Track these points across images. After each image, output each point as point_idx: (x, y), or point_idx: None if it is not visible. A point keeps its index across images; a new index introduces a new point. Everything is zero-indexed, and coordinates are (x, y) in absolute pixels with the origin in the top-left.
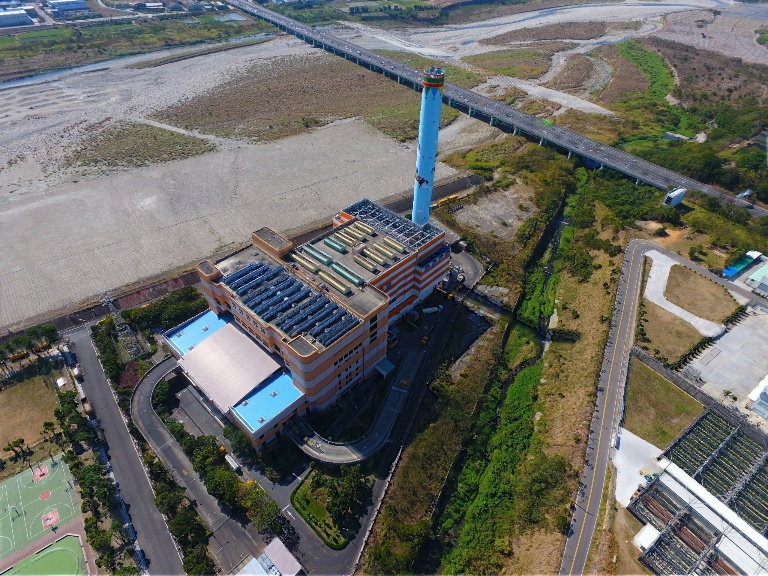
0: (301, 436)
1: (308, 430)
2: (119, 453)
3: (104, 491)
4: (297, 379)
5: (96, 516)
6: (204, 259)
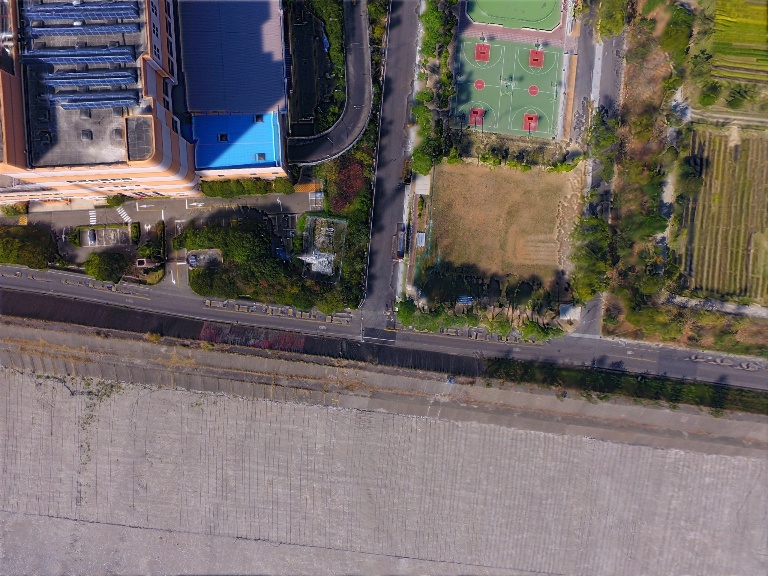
0: None
1: None
2: (401, 81)
3: None
4: None
5: None
6: (142, 370)
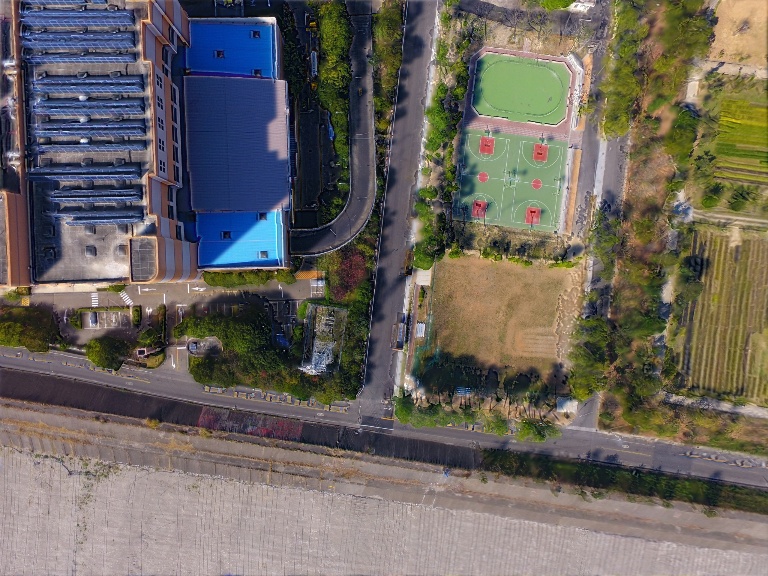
0: (232, 15)
1: (220, 15)
2: (406, 172)
3: (438, 90)
4: (179, 20)
5: (452, 114)
6: (139, 454)
